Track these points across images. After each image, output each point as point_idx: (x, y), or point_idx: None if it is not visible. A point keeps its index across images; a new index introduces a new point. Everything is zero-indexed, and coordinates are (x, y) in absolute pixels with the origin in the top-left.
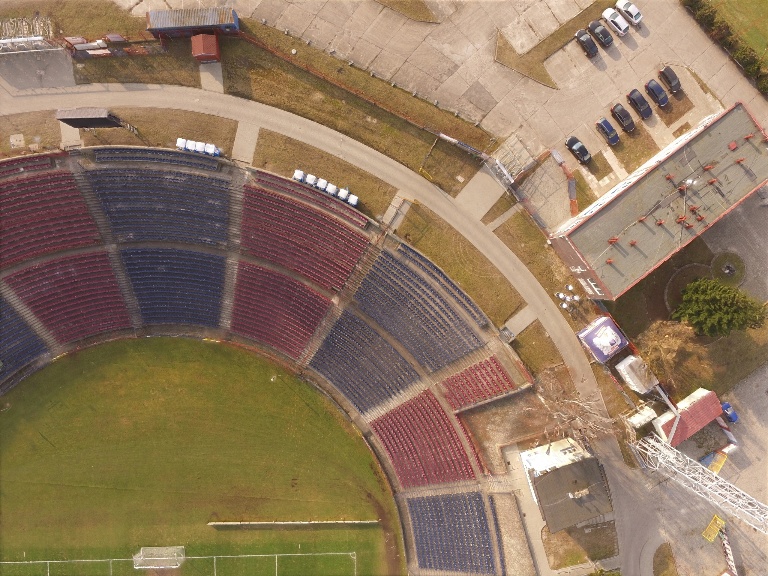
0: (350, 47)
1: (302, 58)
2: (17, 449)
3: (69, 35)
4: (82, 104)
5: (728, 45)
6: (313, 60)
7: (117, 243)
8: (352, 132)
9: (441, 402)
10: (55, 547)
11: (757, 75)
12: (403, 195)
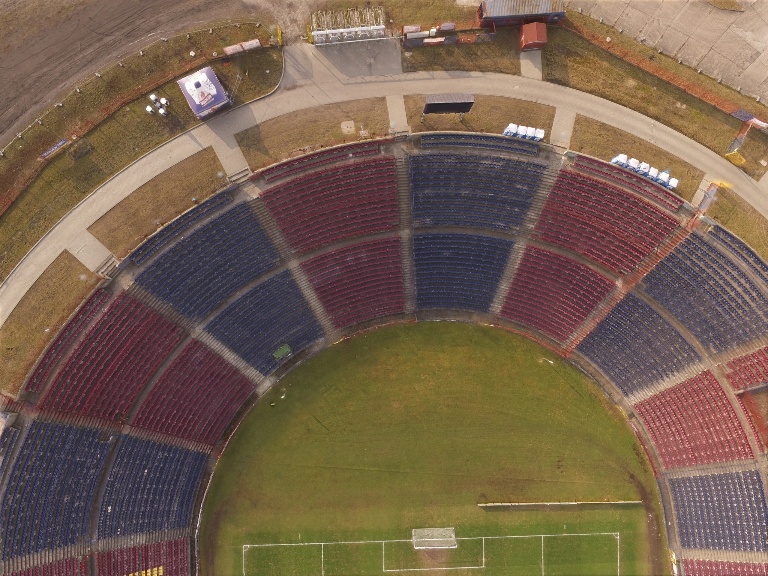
0: (659, 35)
1: (616, 46)
2: (292, 433)
3: (399, 24)
4: (409, 91)
5: None
6: (626, 48)
7: (411, 229)
8: (662, 118)
9: (720, 383)
10: (329, 529)
11: None
12: (710, 179)
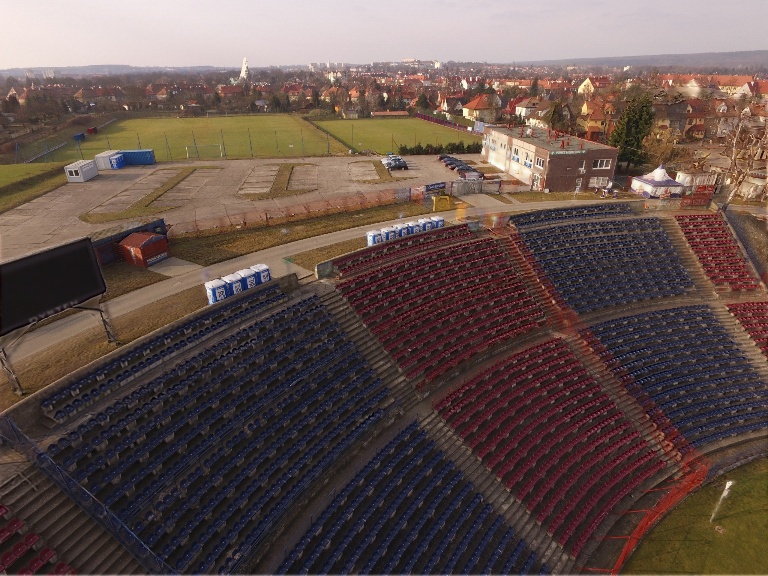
0: (279, 212)
1: (251, 226)
2: None
3: None
4: None
5: (441, 150)
6: (262, 223)
7: None
8: (358, 224)
9: None
10: None
11: (465, 150)
12: (452, 220)
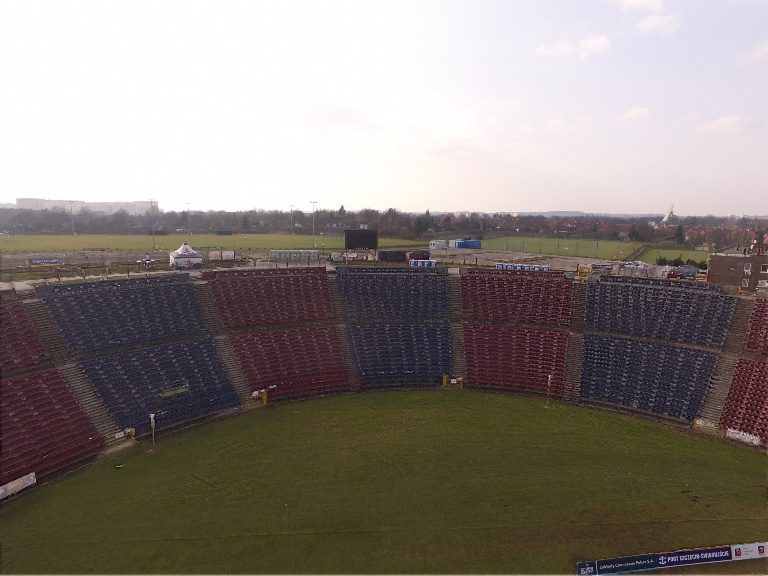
0: None
1: None
2: (136, 496)
3: None
4: None
5: (702, 265)
6: None
7: (347, 323)
8: None
9: None
10: None
11: None
12: None
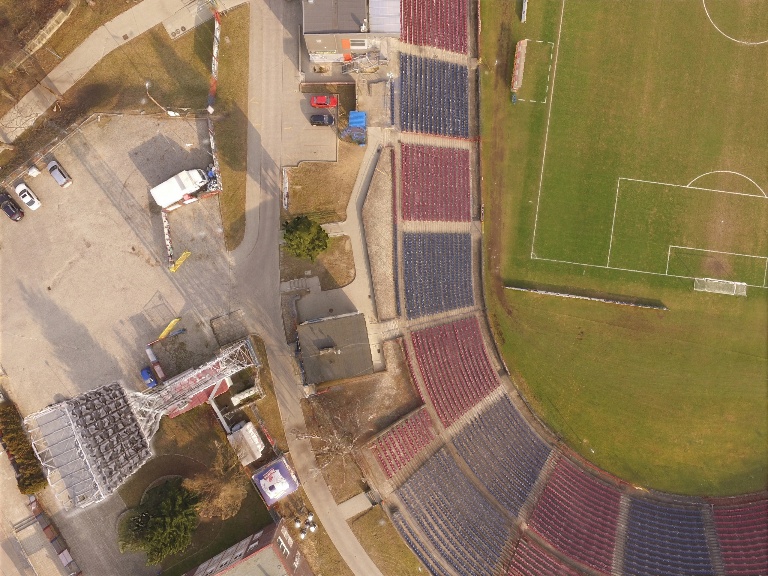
0: None
1: None
2: None
3: None
4: None
5: None
6: None
7: None
8: None
9: (435, 414)
10: None
11: None
12: None
